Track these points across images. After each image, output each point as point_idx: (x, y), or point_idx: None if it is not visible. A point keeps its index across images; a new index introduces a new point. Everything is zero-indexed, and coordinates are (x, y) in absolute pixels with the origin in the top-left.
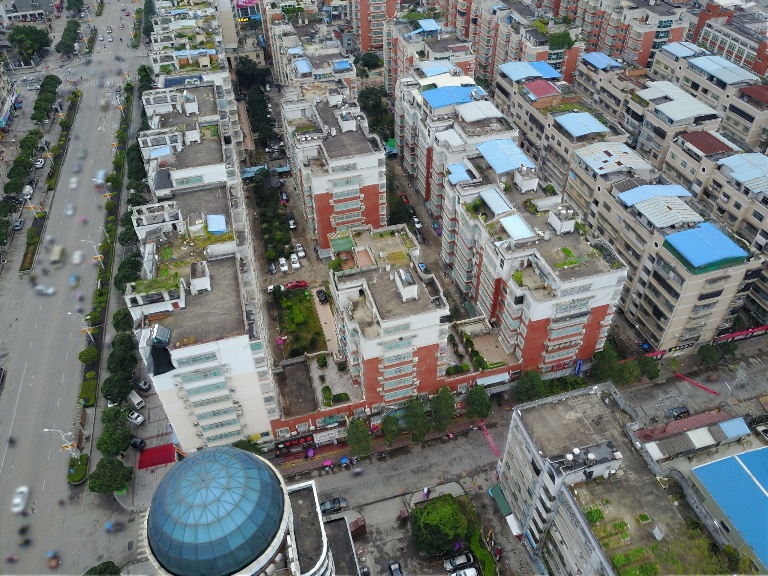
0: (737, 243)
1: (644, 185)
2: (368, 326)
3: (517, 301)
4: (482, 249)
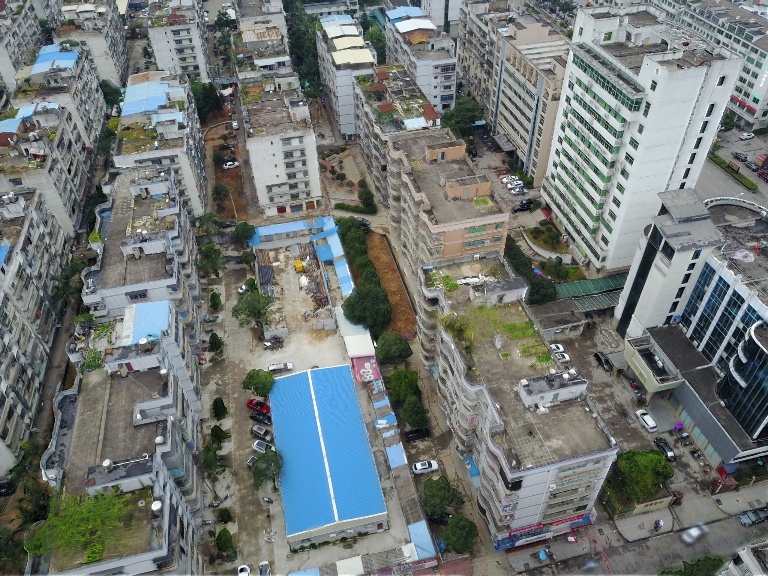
0: None
1: None
2: None
3: None
4: None
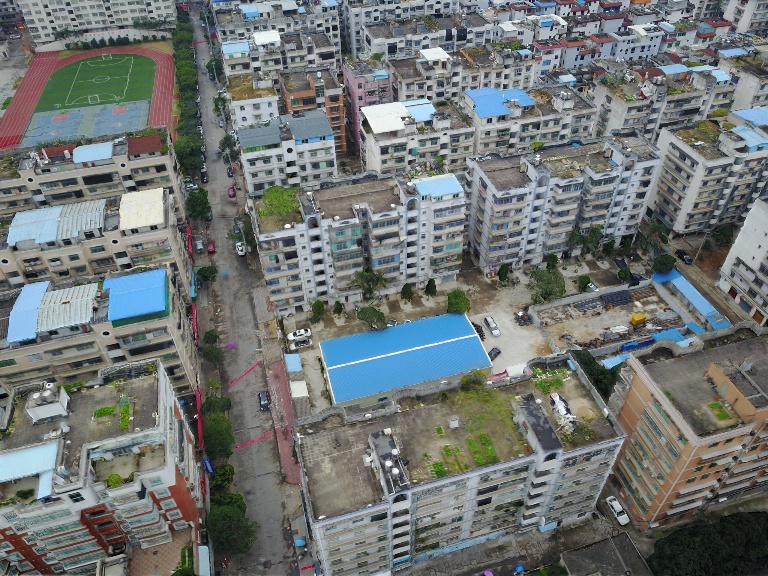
0: (135, 273)
1: (11, 313)
2: None
3: (142, 494)
4: (6, 530)
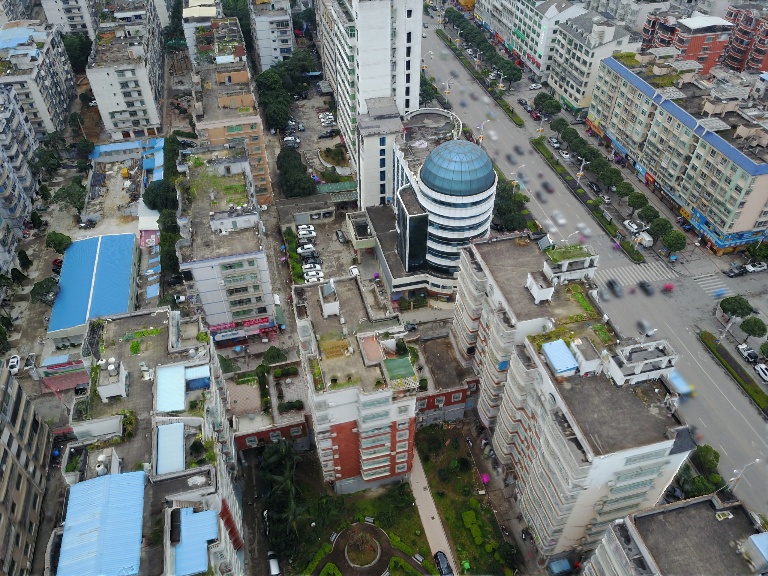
0: None
1: None
2: (371, 306)
3: None
4: None
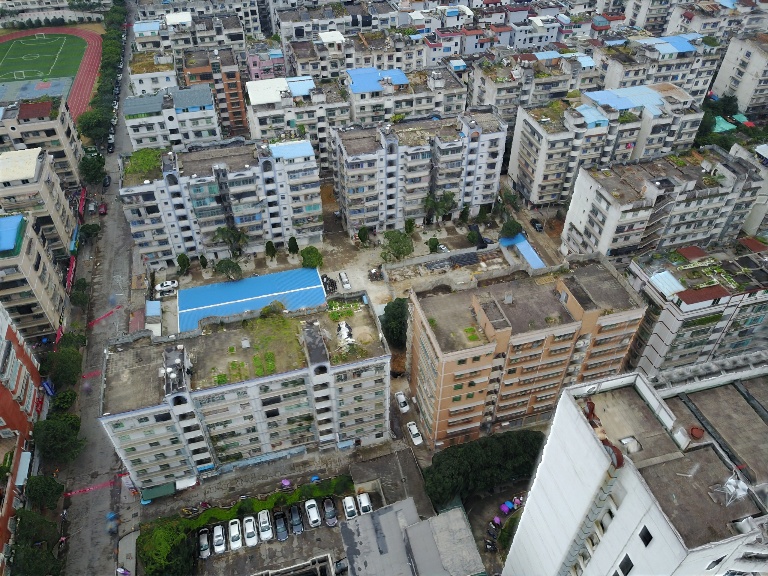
0: None
1: None
2: None
3: None
4: None
